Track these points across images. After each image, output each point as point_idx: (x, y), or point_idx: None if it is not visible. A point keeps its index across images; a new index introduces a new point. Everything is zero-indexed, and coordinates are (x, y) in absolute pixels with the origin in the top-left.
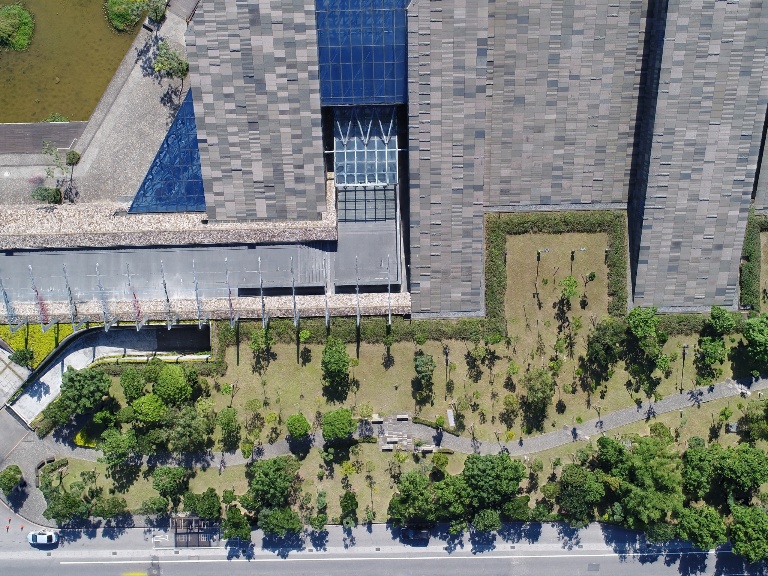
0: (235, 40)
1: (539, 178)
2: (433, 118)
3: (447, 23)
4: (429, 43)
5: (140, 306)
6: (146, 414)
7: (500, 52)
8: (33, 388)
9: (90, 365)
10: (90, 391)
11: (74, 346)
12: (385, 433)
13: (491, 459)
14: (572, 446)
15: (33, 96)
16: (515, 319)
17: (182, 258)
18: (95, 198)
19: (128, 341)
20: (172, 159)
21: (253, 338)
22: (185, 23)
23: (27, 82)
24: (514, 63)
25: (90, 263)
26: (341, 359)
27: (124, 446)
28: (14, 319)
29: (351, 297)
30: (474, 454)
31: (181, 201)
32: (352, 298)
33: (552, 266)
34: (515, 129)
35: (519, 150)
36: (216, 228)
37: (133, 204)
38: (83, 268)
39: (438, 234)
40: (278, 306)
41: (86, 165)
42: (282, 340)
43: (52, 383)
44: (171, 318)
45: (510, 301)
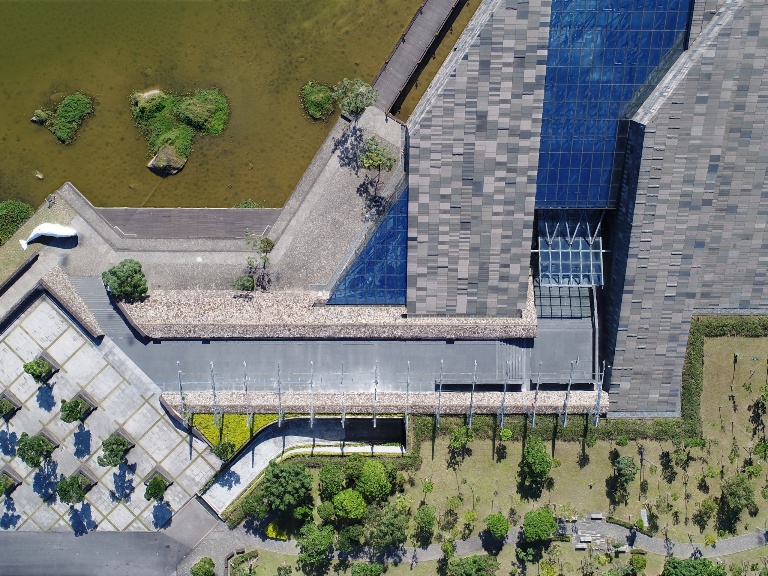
0: (459, 144)
1: (741, 283)
2: (656, 228)
3: (683, 140)
4: (662, 158)
5: (337, 399)
6: (348, 511)
7: (719, 163)
8: (224, 477)
9: (284, 456)
10: (295, 488)
11: (264, 435)
12: (578, 532)
13: (693, 565)
14: (764, 549)
15: (226, 181)
16: (710, 421)
17: (380, 351)
18: (287, 286)
19: (317, 431)
20: (367, 250)
21: (453, 435)
22: (384, 115)
23: (220, 167)
24: (731, 174)
25: (287, 354)
26: (543, 459)
27: (325, 543)
28: (210, 409)
29: (549, 395)
30: (675, 558)
31: (375, 292)
32: (550, 396)
33: (748, 369)
34: (724, 236)
35: (725, 256)
36: (417, 323)
37: (332, 296)
38: (280, 358)
39: (645, 338)
40: (477, 403)
41: (280, 253)
42: (478, 436)
43: (242, 472)
44: (368, 412)
45: (706, 403)
